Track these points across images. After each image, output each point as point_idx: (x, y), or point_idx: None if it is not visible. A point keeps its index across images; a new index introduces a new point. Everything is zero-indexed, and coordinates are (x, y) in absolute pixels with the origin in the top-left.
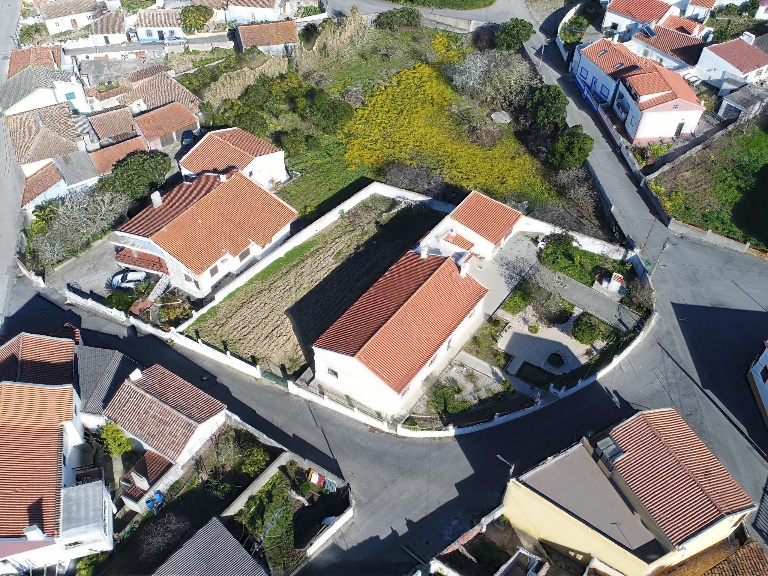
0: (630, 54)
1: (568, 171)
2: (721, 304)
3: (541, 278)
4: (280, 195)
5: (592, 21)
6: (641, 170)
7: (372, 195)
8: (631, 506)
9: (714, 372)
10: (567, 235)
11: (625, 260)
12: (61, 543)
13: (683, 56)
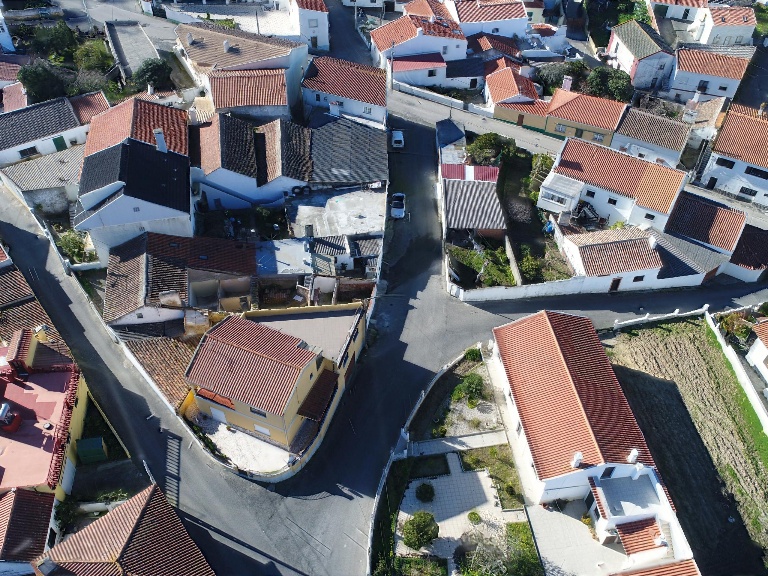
0: None
1: None
2: None
3: None
4: None
5: None
6: None
7: None
8: None
9: None
10: None
11: None
12: None
13: None
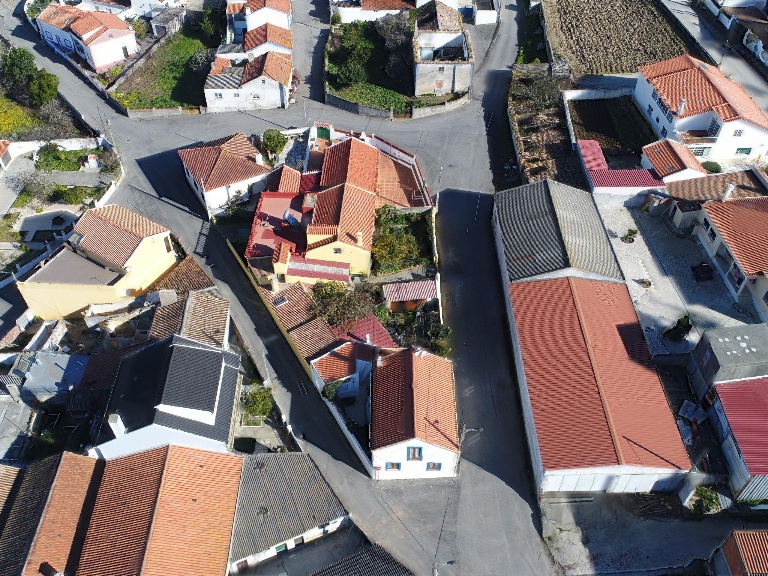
0: (77, 11)
1: (47, 105)
2: (168, 149)
3: (40, 179)
4: None
5: None
6: (106, 88)
7: None
8: (102, 266)
9: (166, 187)
10: (51, 144)
11: None
12: None
13: (122, 2)
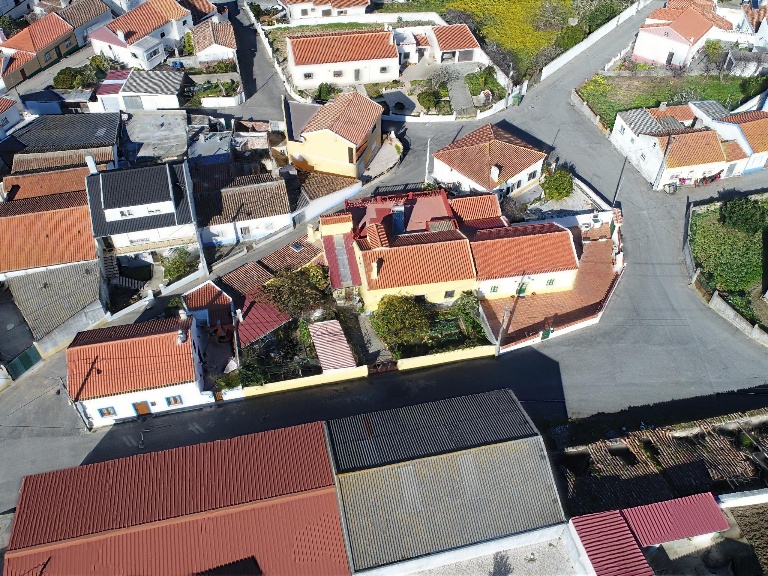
0: (704, 7)
1: None
2: (531, 132)
3: (453, 82)
4: (386, 4)
5: None
6: None
7: (430, 21)
8: None
9: None
10: (493, 67)
11: None
12: (130, 50)
13: None
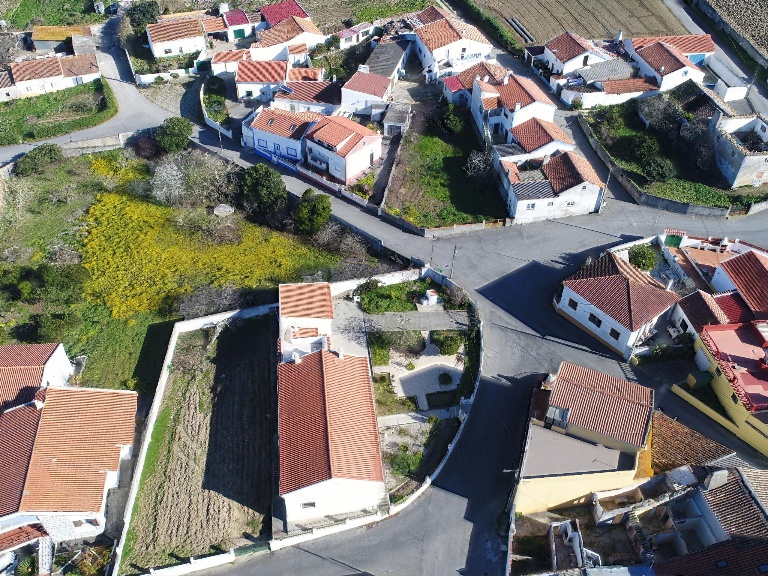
0: (291, 114)
1: (324, 230)
2: (503, 273)
3: (379, 325)
4: (86, 387)
5: (224, 95)
6: (369, 203)
7: (179, 337)
8: (592, 442)
9: (539, 322)
10: (372, 281)
11: (422, 277)
12: None
13: (325, 100)
